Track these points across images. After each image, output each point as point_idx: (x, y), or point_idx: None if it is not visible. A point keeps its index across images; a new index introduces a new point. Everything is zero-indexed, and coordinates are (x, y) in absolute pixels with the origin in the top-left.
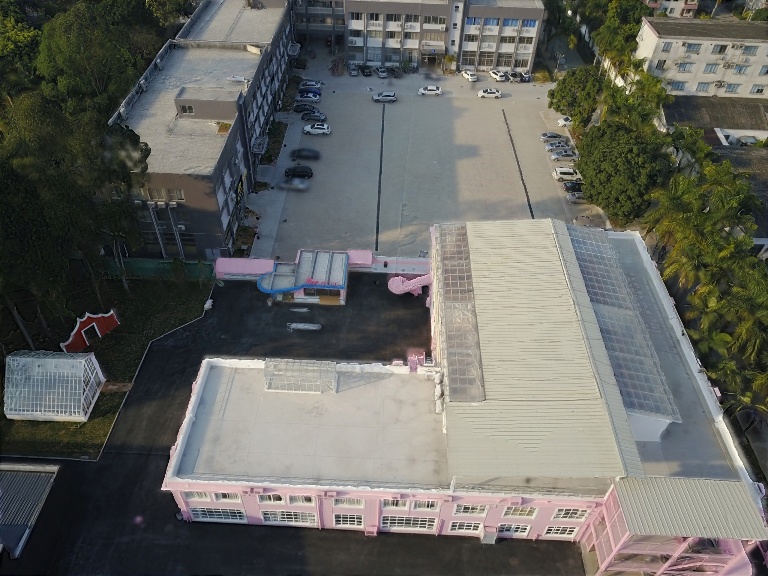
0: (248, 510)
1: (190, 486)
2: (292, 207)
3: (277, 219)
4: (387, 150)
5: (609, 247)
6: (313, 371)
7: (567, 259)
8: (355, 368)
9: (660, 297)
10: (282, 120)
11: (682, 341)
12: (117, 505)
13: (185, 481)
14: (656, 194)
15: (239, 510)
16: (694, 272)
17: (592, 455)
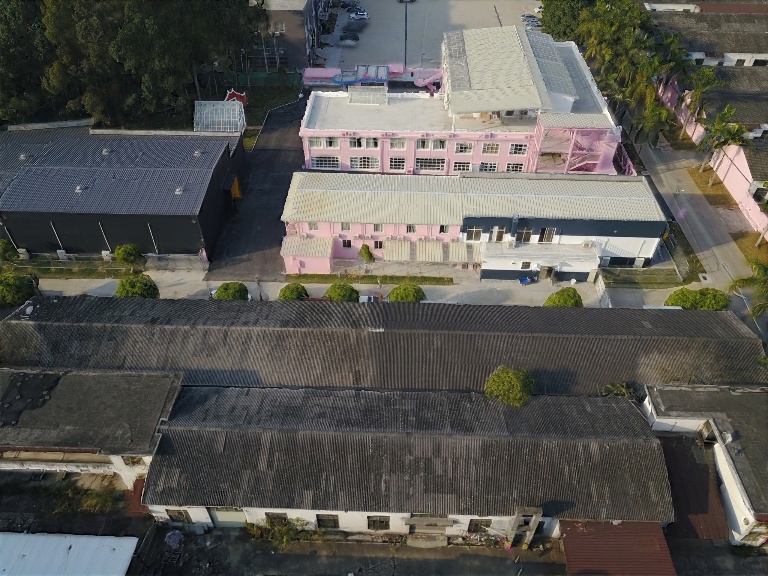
0: (343, 156)
1: (314, 133)
2: (347, 55)
3: (338, 61)
4: (410, 27)
5: (551, 41)
6: (375, 89)
7: (523, 41)
8: (398, 95)
9: (583, 69)
10: (333, 12)
11: (591, 84)
12: (268, 164)
13: (312, 130)
14: (583, 14)
15: (337, 158)
16: (600, 46)
17: (526, 102)
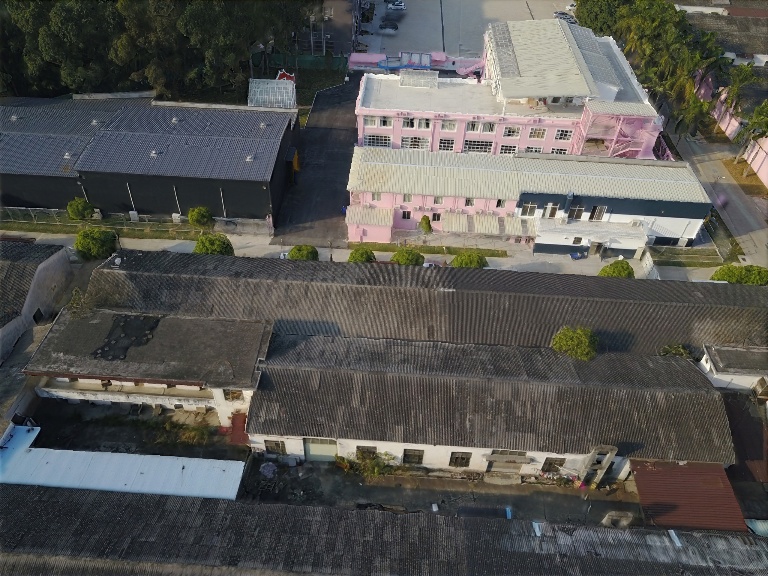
0: (395, 136)
1: (370, 112)
2: (387, 43)
3: (379, 48)
4: (446, 19)
5: (592, 35)
6: (427, 73)
7: (566, 33)
8: (447, 80)
9: (621, 63)
10: (371, 2)
11: (631, 77)
12: (321, 141)
13: (368, 109)
14: (622, 11)
15: (389, 137)
16: (640, 41)
17: (575, 89)
